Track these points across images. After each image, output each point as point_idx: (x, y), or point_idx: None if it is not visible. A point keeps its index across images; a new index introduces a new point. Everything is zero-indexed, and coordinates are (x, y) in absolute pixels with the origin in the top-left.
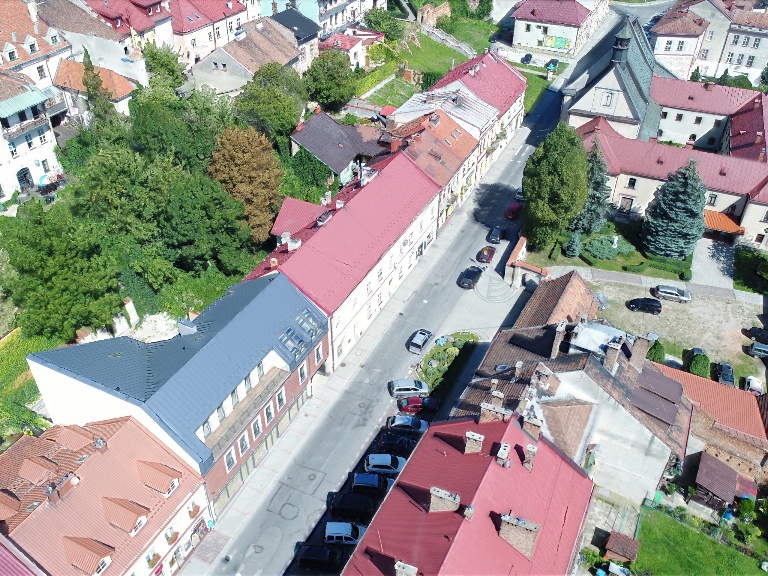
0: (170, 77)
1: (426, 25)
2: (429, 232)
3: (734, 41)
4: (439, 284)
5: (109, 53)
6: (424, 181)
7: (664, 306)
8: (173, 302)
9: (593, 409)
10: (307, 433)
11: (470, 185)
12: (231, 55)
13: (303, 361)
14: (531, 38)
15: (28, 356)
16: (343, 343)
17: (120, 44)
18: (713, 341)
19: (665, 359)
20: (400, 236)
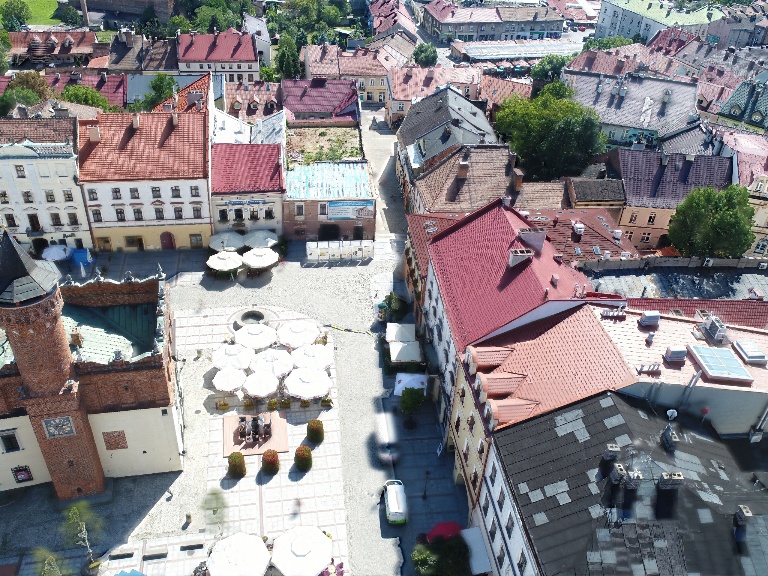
0: None
1: None
2: None
3: None
4: None
5: None
6: None
7: None
8: None
9: None
10: None
11: None
12: None
13: None
14: None
15: (223, 93)
16: None
17: None
18: None
19: None
20: None
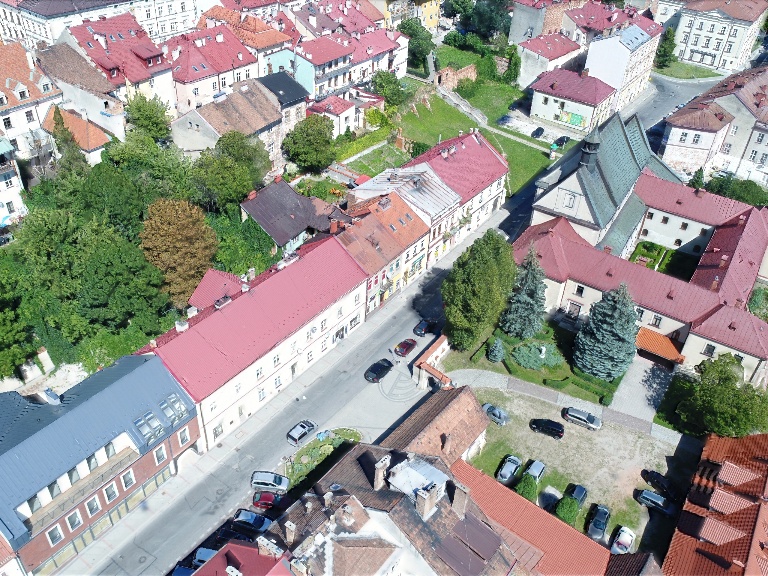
0: (145, 132)
1: (443, 87)
2: (353, 317)
3: (758, 139)
4: (347, 372)
5: (91, 105)
6: (351, 268)
7: (570, 430)
8: (89, 355)
9: (394, 553)
10: (157, 512)
11: (419, 269)
12: (204, 117)
13: (161, 444)
14: (548, 111)
15: None
16: (223, 424)
17: (100, 99)
18: (606, 478)
19: (545, 491)
20: (305, 324)
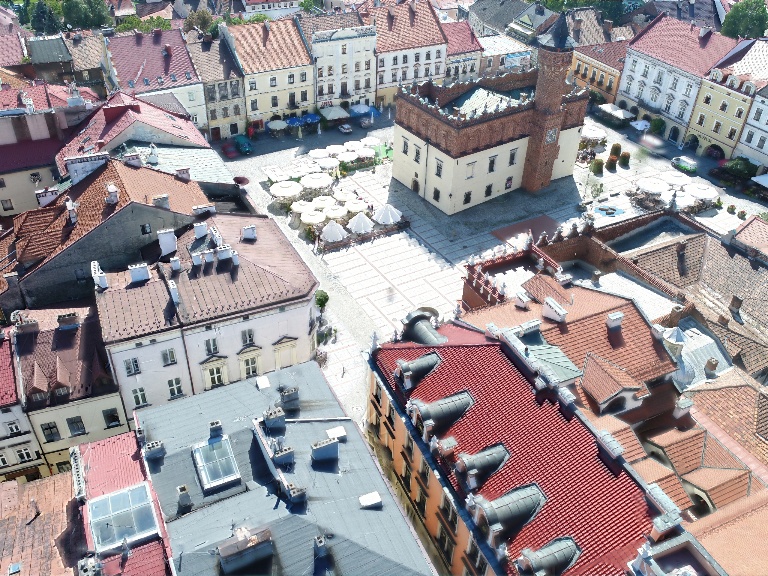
0: None
1: None
2: None
3: None
4: None
5: None
6: None
7: None
8: None
9: None
10: None
11: None
12: None
13: None
14: None
15: None
16: None
17: (194, 29)
18: None
19: None
20: None
